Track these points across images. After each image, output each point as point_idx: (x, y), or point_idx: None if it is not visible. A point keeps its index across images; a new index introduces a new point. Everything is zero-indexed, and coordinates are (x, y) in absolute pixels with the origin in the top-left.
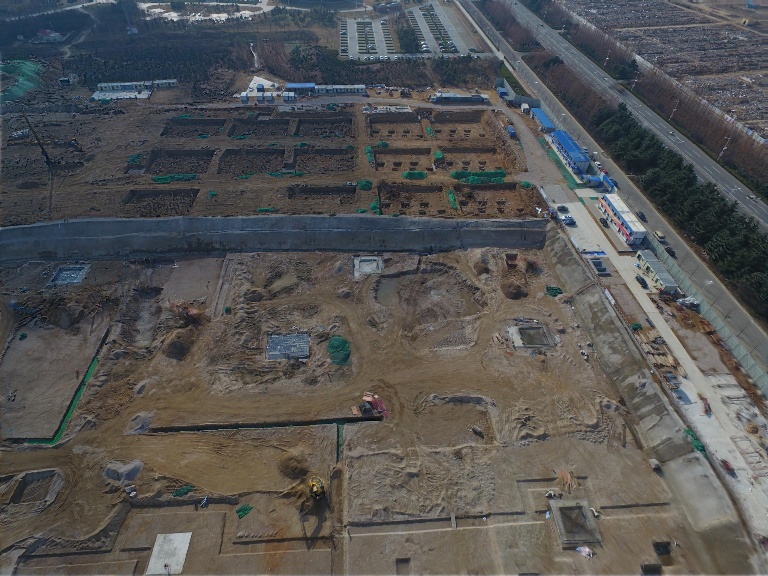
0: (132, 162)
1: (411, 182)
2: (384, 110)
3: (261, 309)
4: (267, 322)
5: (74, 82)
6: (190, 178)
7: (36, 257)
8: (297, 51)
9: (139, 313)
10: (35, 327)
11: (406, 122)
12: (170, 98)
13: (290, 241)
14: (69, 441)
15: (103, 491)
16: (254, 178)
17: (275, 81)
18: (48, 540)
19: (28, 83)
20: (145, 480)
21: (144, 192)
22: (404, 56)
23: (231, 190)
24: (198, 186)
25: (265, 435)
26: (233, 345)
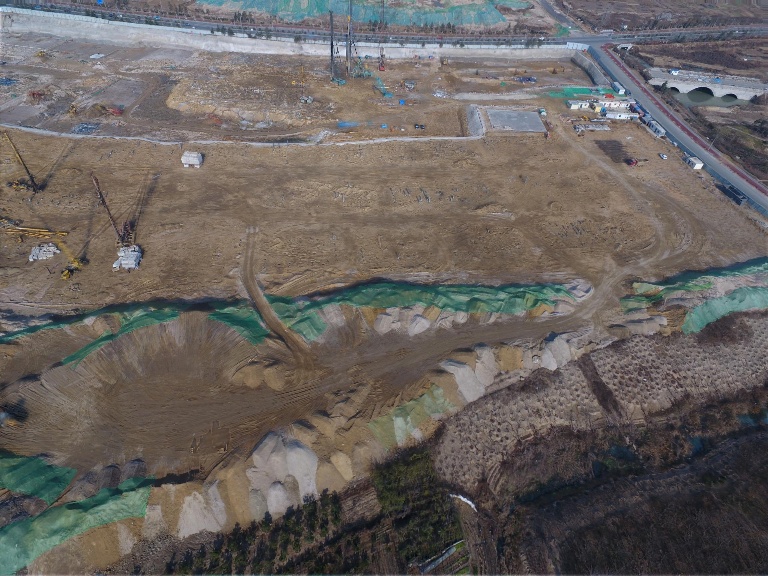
0: None
1: None
2: None
3: None
4: (2, 89)
5: None
6: None
7: None
8: None
9: None
10: None
11: None
12: None
13: None
14: None
15: None
16: None
17: None
18: None
19: None
20: None
21: None
22: None
23: None
24: None
25: (45, 65)
26: None
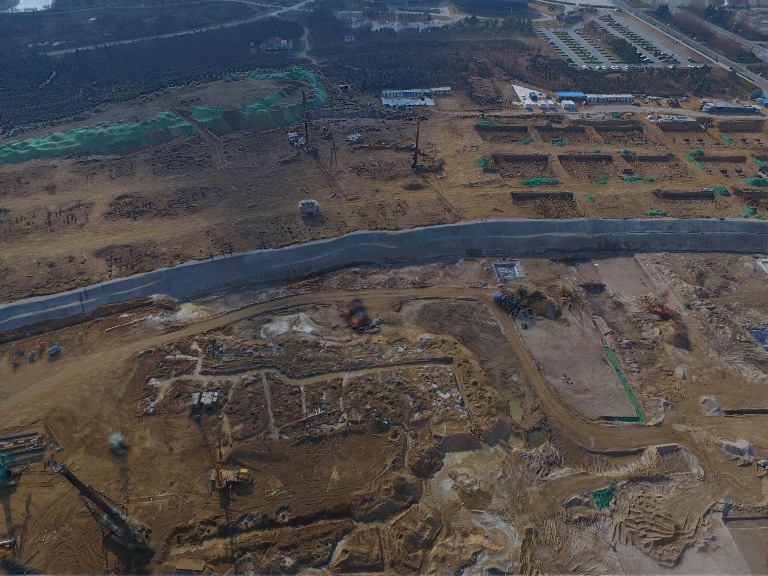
0: (486, 166)
1: (761, 189)
2: (668, 119)
3: (717, 305)
4: (735, 317)
5: (350, 89)
6: (555, 182)
7: (463, 254)
8: (535, 60)
9: (600, 307)
10: (526, 318)
11: (692, 131)
12: (457, 105)
13: (689, 243)
14: (664, 420)
15: (737, 464)
16: (612, 183)
17: (537, 90)
18: (732, 505)
19: (319, 89)
20: (765, 456)
21: (522, 195)
22: (633, 66)
23: (603, 194)
24: (569, 190)
25: None
26: (724, 338)
